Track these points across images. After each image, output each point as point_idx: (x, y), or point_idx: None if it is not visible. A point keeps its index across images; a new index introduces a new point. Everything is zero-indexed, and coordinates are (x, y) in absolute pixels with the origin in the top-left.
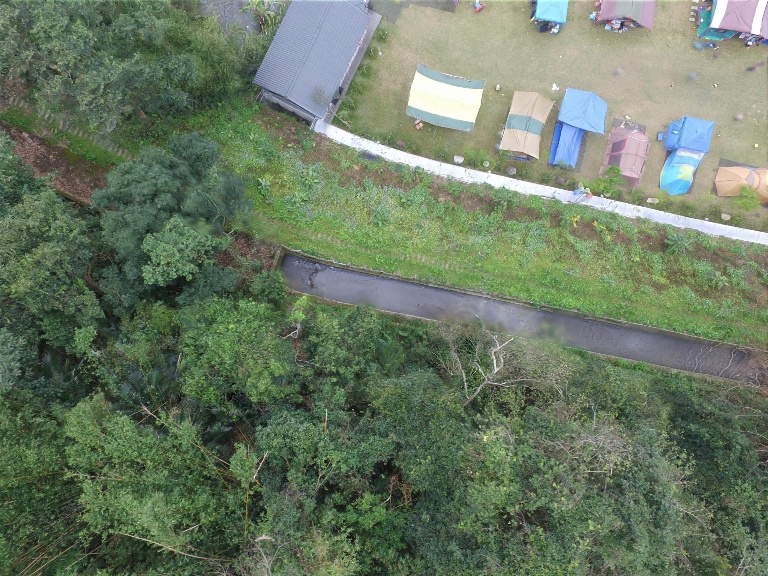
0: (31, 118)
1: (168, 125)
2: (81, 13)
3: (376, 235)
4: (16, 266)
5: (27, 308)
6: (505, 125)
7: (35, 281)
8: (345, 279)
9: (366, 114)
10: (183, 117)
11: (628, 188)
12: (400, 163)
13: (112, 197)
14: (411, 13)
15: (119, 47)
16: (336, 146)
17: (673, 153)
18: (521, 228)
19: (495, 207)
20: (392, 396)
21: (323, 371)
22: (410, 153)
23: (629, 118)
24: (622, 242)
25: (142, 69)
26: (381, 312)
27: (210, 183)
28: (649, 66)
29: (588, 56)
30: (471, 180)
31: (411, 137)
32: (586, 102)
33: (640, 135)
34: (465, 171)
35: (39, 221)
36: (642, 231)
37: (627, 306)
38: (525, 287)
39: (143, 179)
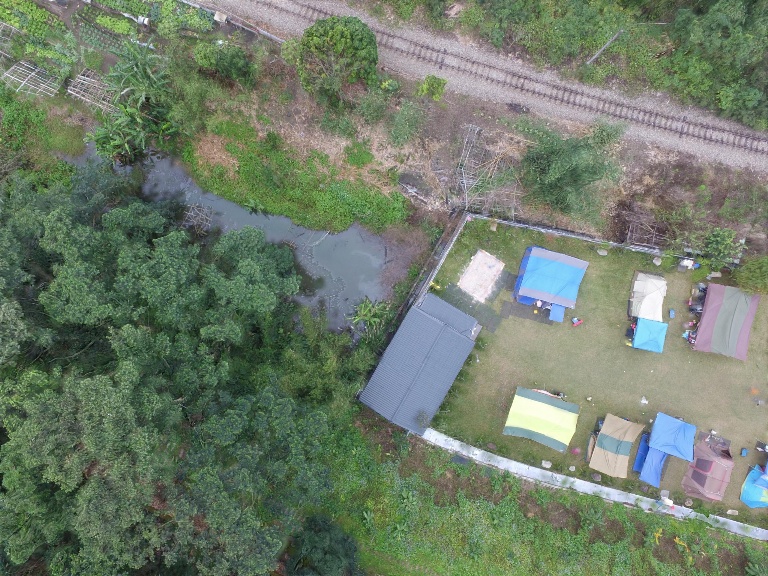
0: None
1: None
2: (247, 490)
3: (471, 569)
4: None
5: None
6: (595, 442)
7: None
8: None
9: (460, 416)
10: None
11: (709, 499)
12: (490, 466)
13: None
14: (510, 324)
15: (233, 355)
16: (430, 449)
17: (757, 475)
18: (607, 551)
19: (581, 523)
20: None
21: None
22: (500, 456)
23: (714, 433)
24: (703, 564)
25: (254, 380)
26: None
27: None
28: (737, 384)
29: (678, 372)
30: (557, 484)
31: (502, 440)
32: (677, 430)
33: (727, 461)
34: (552, 475)
35: None
36: (722, 548)
37: None
38: None
39: None
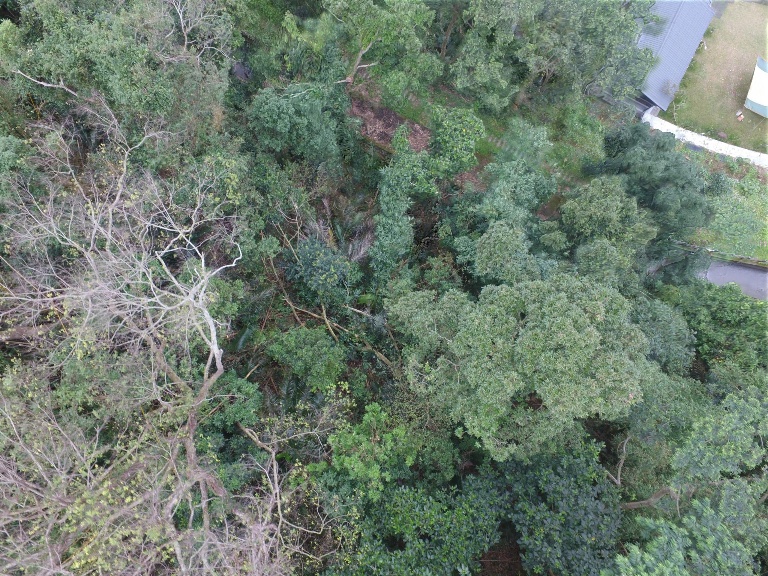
0: (418, 111)
1: (536, 117)
2: None
3: None
4: (608, 244)
5: None
6: None
7: None
8: None
9: (690, 106)
10: (543, 109)
11: None
12: (723, 154)
13: (632, 182)
14: (736, 8)
15: None
16: None
17: None
18: None
19: None
20: None
21: None
22: (731, 144)
23: None
24: None
25: None
26: None
27: None
28: None
29: None
30: None
31: (732, 129)
32: None
33: None
34: None
35: None
36: None
37: None
38: None
39: (672, 165)
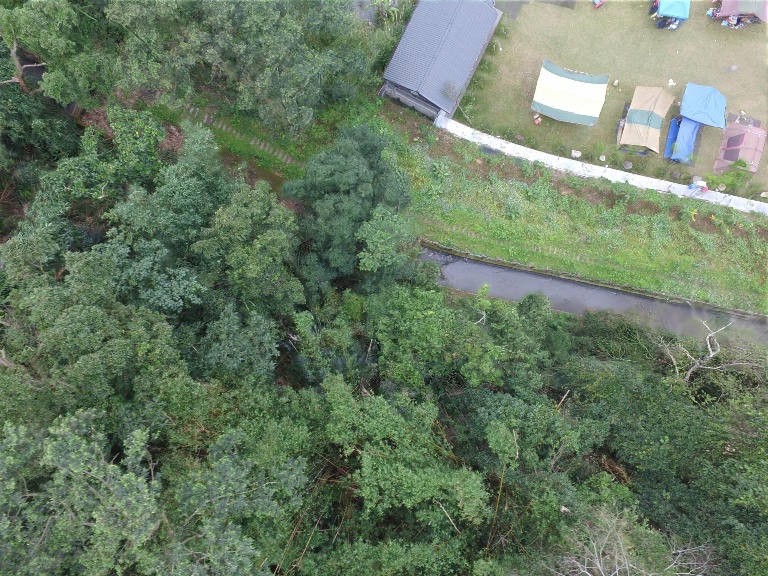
0: (177, 112)
1: None
2: (284, 8)
3: (509, 227)
4: (242, 252)
5: (253, 293)
6: (625, 120)
7: (260, 267)
8: (476, 271)
9: (486, 109)
10: (318, 111)
11: None
12: (519, 157)
13: (309, 187)
14: (531, 9)
15: None
16: (458, 140)
17: None
18: (644, 221)
19: (616, 201)
20: (606, 380)
21: (515, 357)
22: (529, 147)
23: (744, 113)
24: (741, 235)
25: None
26: (513, 303)
27: (382, 174)
28: (764, 62)
29: (704, 52)
30: (588, 174)
31: (529, 132)
32: (707, 97)
33: (759, 130)
34: (582, 165)
35: (260, 209)
36: (758, 225)
37: (754, 298)
38: (654, 279)
39: (343, 169)
